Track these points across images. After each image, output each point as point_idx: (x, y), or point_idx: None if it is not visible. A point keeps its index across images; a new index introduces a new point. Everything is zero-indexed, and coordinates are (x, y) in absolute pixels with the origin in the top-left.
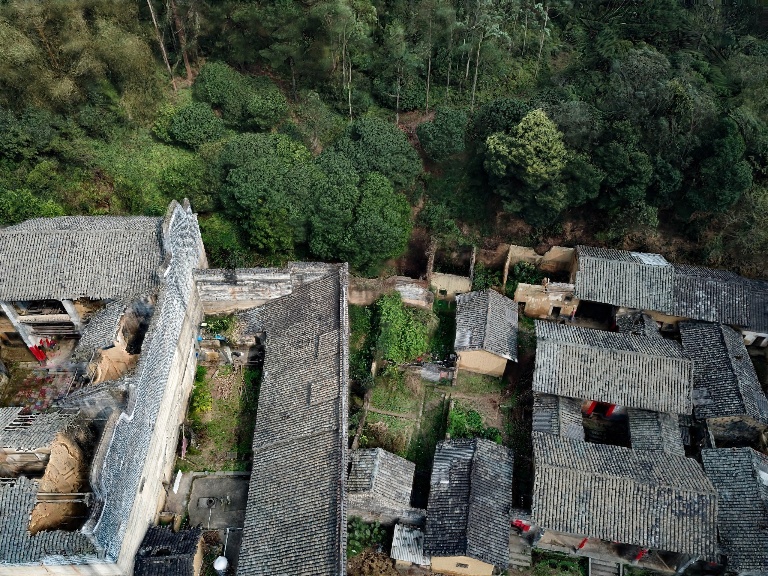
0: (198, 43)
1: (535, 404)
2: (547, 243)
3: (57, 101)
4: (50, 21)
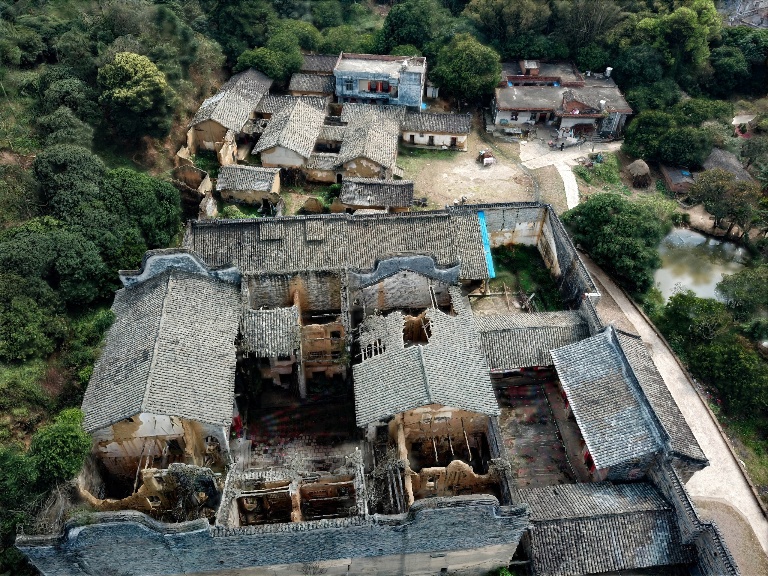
0: None
1: (312, 167)
2: (168, 149)
3: None
4: None
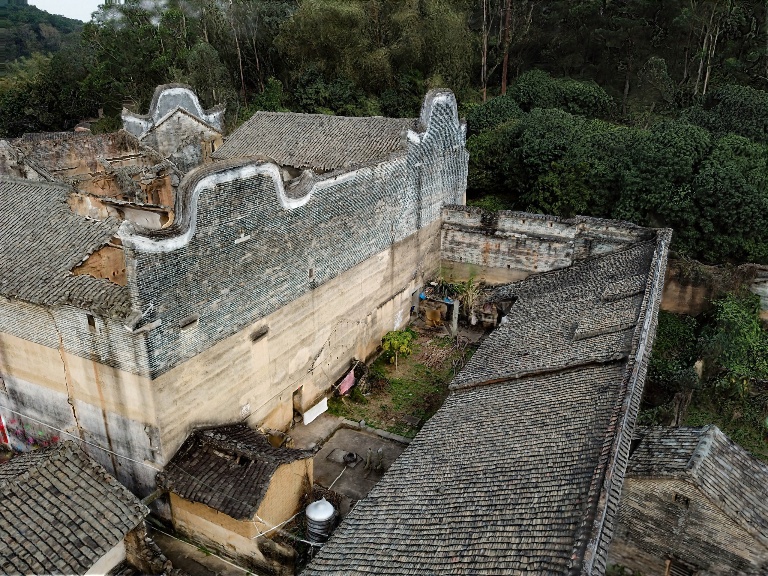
0: (522, 60)
1: None
2: None
3: (366, 71)
4: (388, 5)
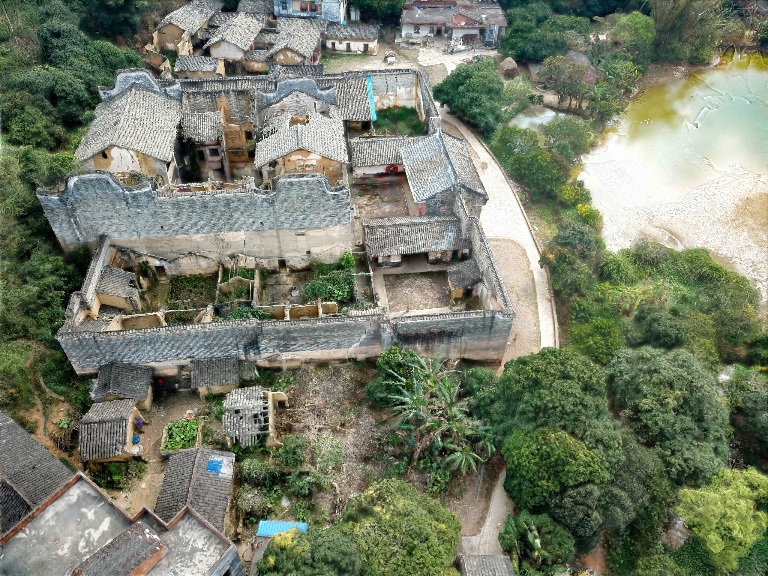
0: None
1: (249, 59)
2: None
3: None
4: None
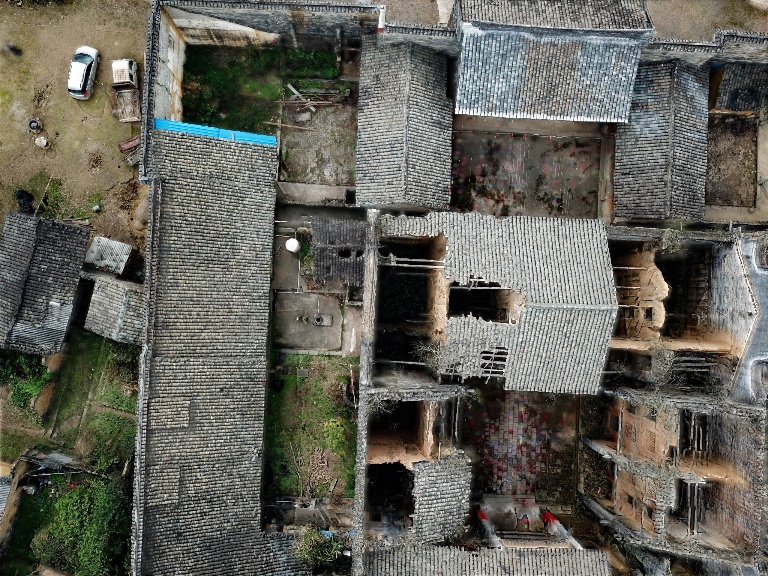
0: None
1: None
2: None
3: None
4: None
